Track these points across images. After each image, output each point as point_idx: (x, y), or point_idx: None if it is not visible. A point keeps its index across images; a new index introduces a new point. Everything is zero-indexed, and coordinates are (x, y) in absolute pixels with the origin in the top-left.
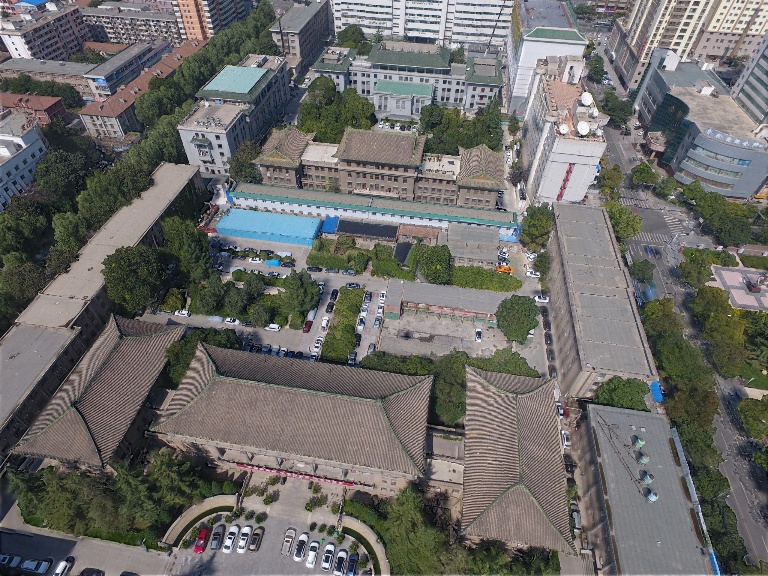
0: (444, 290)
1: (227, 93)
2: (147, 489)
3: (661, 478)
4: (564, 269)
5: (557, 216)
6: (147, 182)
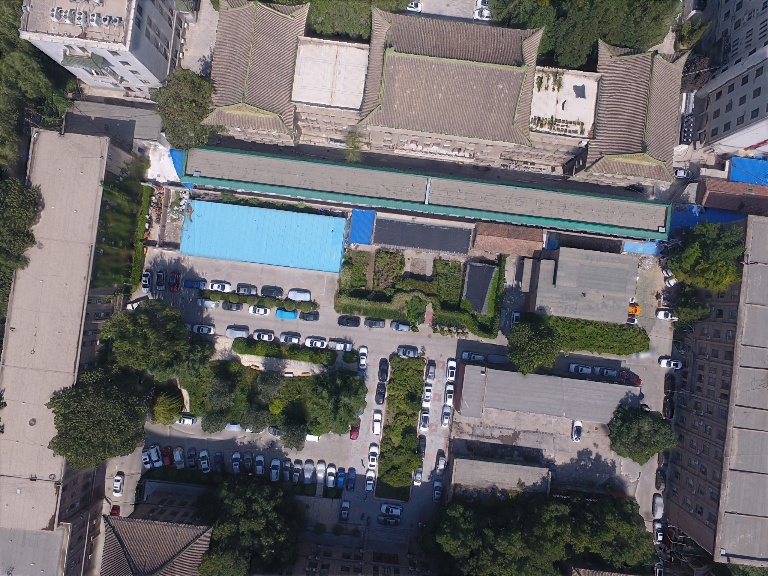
0: (542, 385)
1: None
2: None
3: None
4: (731, 384)
5: (748, 256)
6: (31, 212)
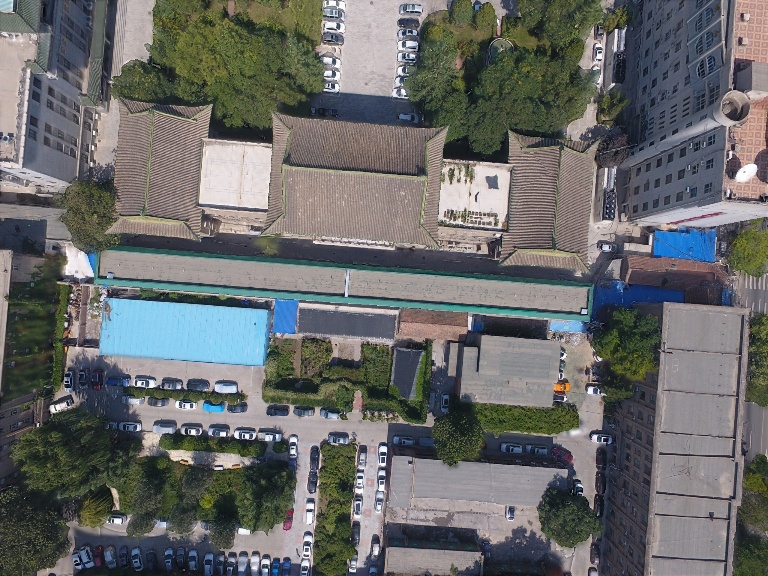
0: (470, 473)
1: None
2: None
3: None
4: (651, 472)
5: (664, 344)
6: None
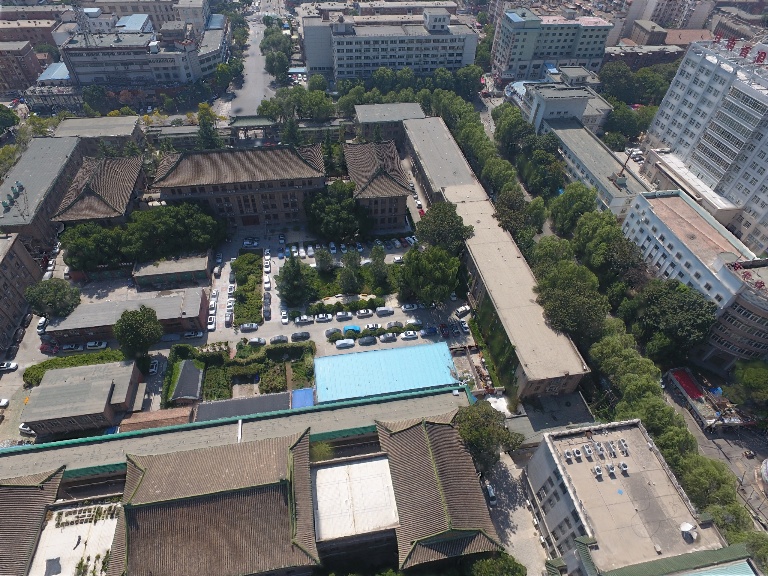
0: None
1: (676, 569)
2: (323, 157)
3: (4, 198)
4: None
5: None
6: None
